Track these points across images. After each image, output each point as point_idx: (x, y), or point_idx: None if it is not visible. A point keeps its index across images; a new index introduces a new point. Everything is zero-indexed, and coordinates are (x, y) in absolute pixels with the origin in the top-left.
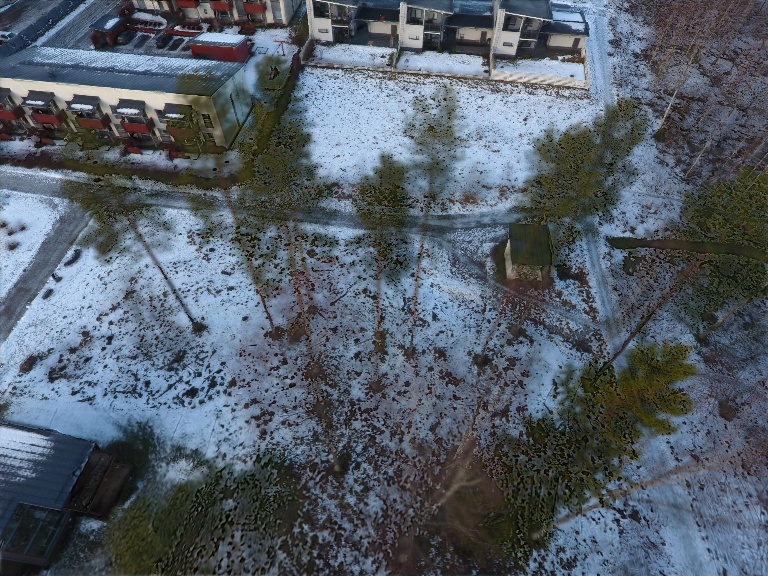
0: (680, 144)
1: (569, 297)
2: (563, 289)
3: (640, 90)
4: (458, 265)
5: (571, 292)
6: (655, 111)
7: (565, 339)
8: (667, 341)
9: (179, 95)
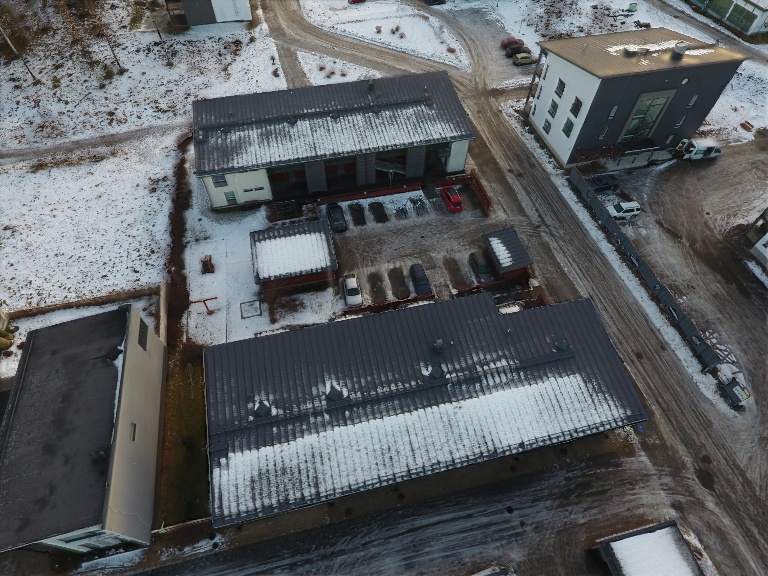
0: None
1: None
2: None
3: None
4: None
5: None
6: None
7: None
8: None
9: None
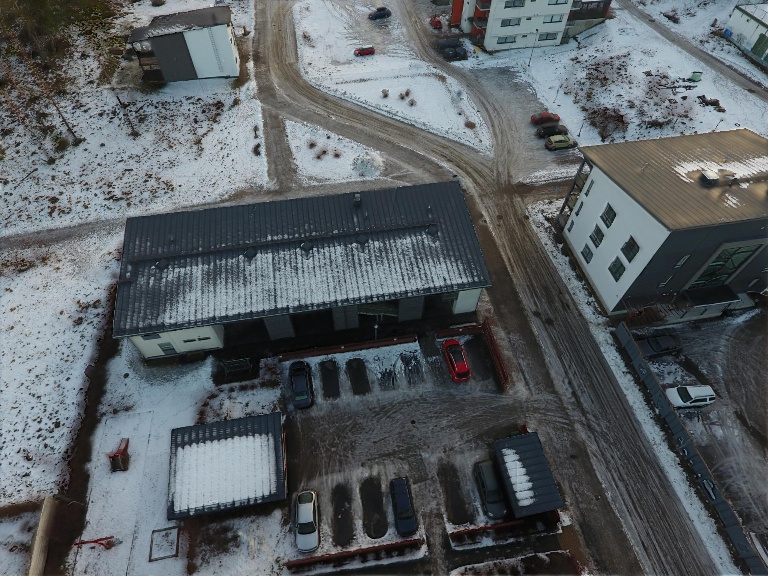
0: None
1: None
2: None
3: None
4: None
5: None
6: None
7: None
8: None
9: None
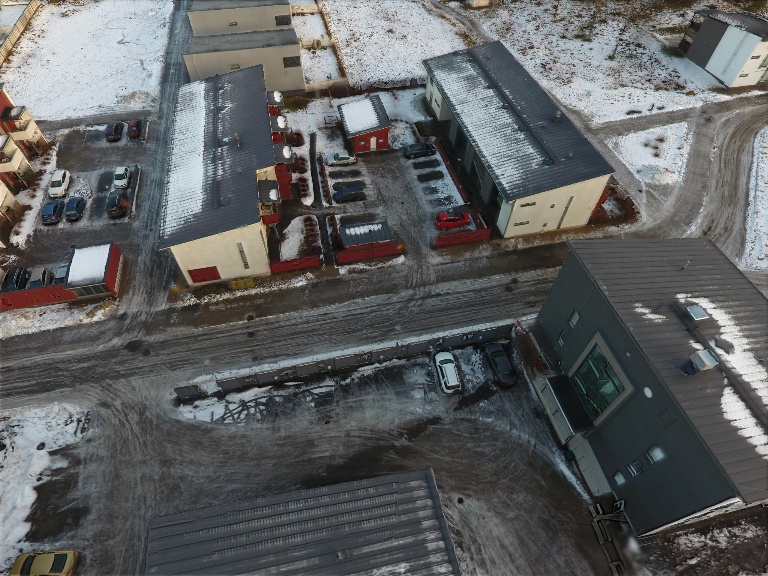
0: None
1: None
2: None
3: None
4: (492, 16)
5: None
6: None
7: None
8: None
9: None
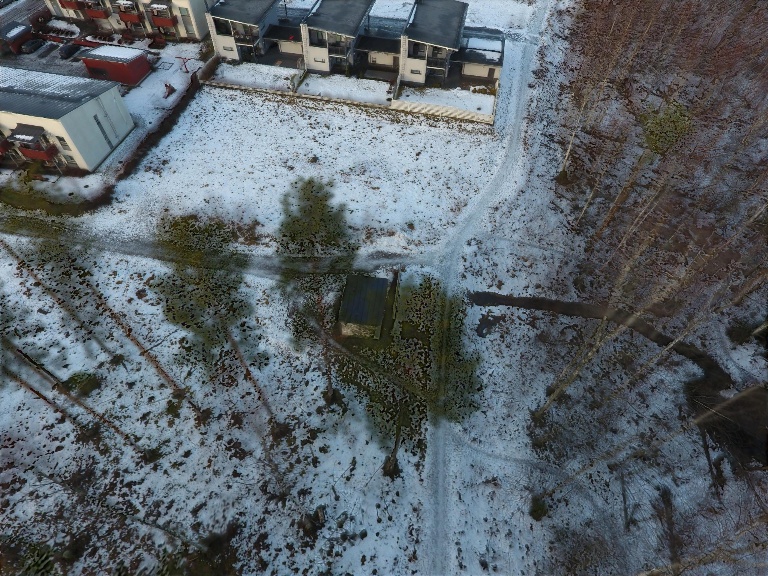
0: (582, 189)
1: (404, 360)
2: (400, 350)
3: (556, 126)
4: (295, 316)
5: (409, 354)
6: (565, 150)
7: (385, 409)
8: (498, 418)
9: (26, 116)
